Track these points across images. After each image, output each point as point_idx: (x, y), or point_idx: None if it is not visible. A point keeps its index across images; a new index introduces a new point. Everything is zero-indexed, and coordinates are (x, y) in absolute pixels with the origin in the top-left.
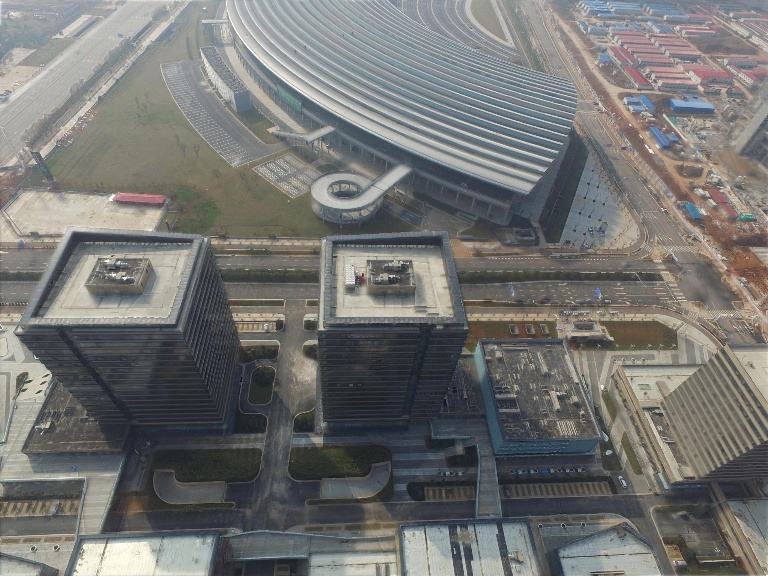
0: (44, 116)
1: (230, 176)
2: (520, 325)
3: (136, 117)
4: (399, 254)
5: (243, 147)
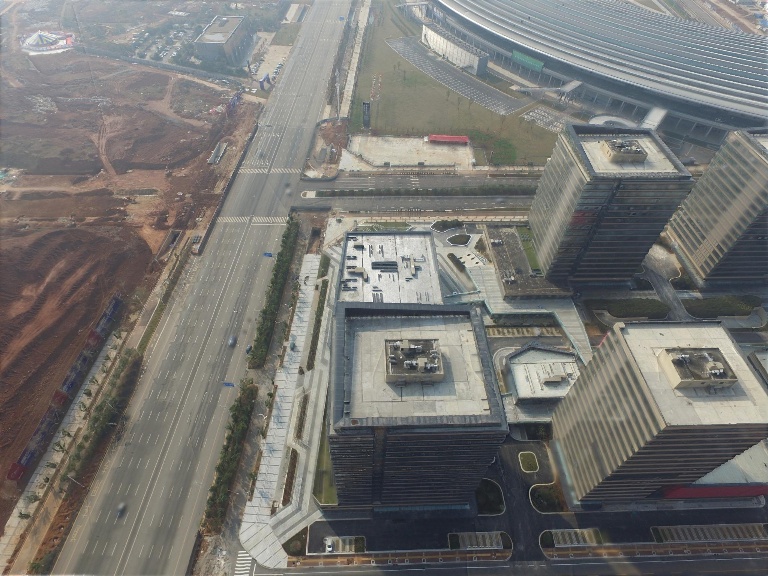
0: (328, 81)
1: (506, 122)
2: None
3: (398, 81)
4: None
5: (500, 101)
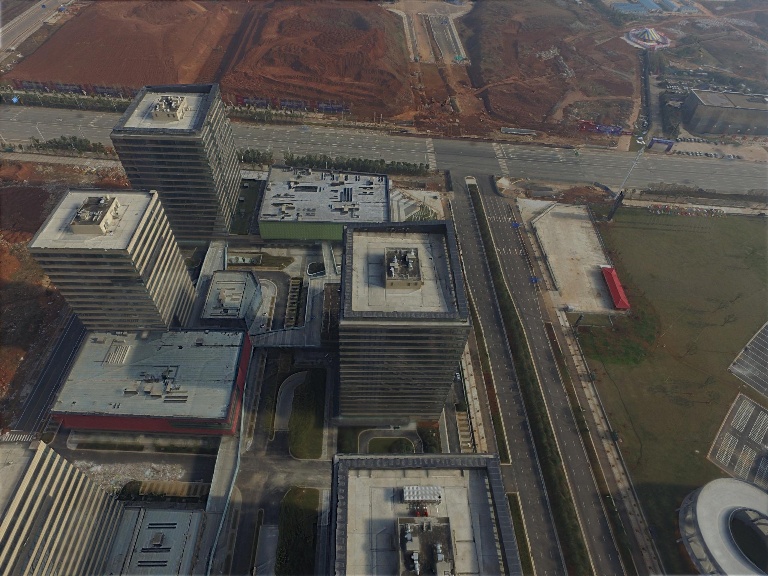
0: (694, 187)
1: (706, 367)
2: None
3: None
4: None
5: None
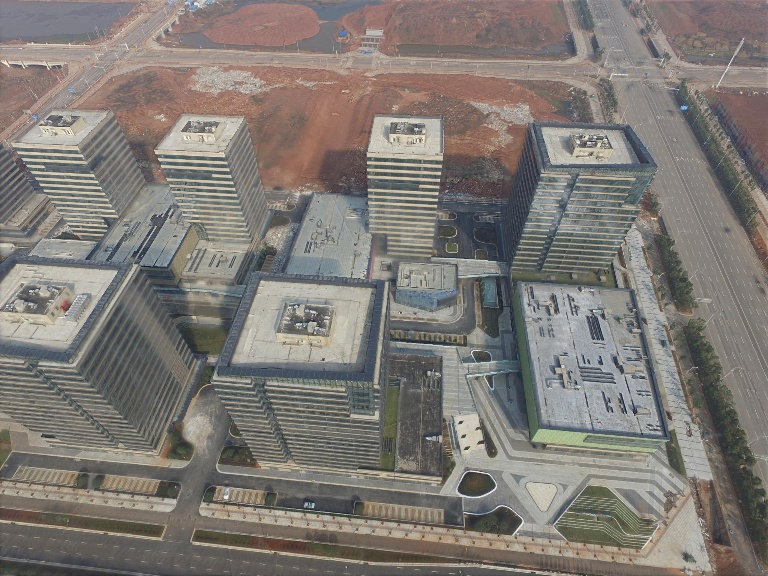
0: None
1: None
2: None
3: None
4: (2, 339)
5: None
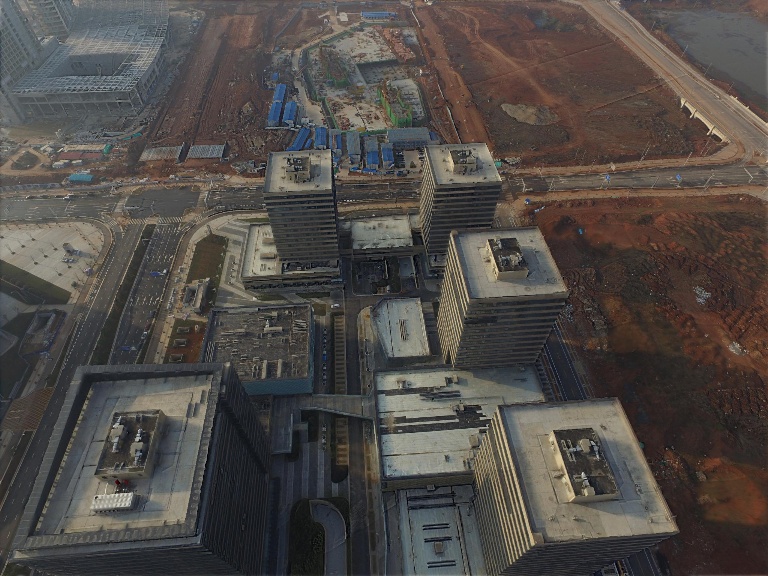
0: None
1: None
2: (172, 351)
3: None
4: (90, 434)
5: None
